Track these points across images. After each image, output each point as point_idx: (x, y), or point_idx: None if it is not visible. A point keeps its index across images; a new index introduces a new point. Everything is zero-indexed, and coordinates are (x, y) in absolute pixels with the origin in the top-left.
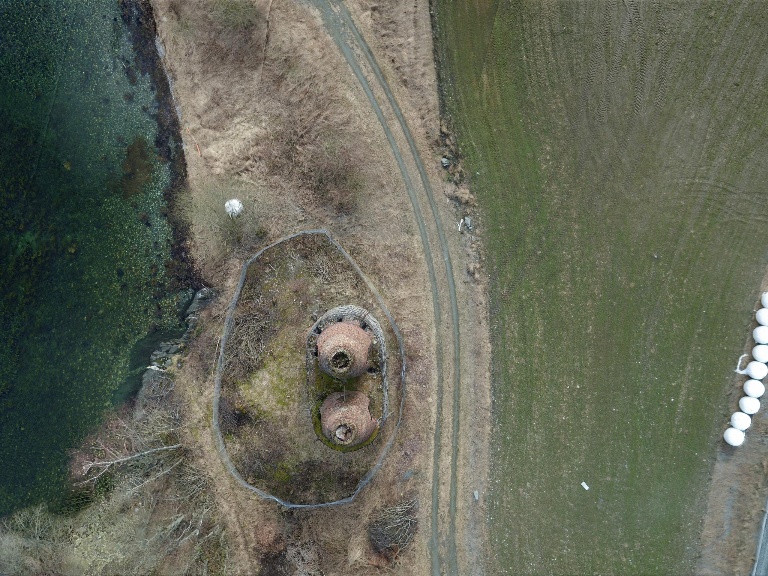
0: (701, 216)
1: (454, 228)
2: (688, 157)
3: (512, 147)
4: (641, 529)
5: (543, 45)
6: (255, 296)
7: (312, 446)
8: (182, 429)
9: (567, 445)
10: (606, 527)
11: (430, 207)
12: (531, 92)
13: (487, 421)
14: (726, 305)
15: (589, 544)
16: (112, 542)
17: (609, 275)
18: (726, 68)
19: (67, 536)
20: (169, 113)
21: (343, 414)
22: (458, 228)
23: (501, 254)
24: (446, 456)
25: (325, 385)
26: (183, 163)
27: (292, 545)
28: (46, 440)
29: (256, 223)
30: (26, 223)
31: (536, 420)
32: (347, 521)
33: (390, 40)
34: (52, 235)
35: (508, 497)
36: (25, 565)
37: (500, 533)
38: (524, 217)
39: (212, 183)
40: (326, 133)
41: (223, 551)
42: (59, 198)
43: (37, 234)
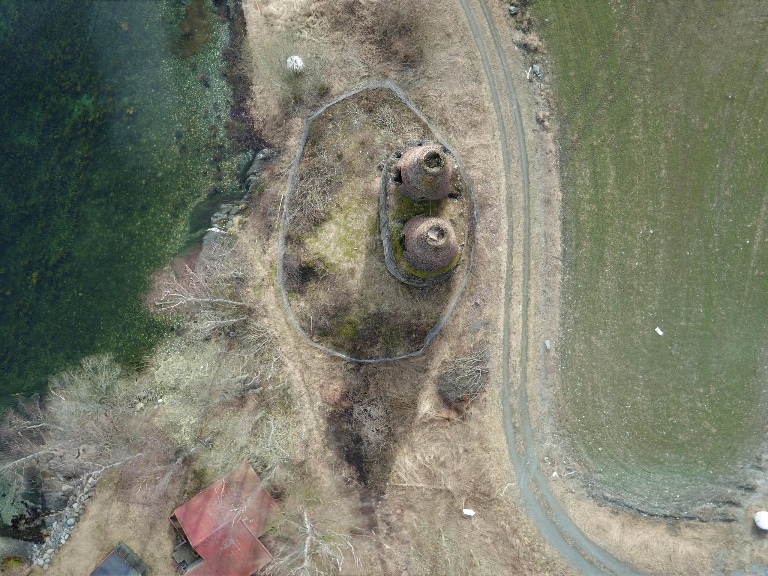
0: None
1: (523, 76)
2: None
3: None
4: (716, 373)
5: None
6: (319, 152)
7: (380, 298)
8: (245, 288)
9: (640, 291)
10: (681, 372)
11: (498, 55)
12: None
13: (558, 270)
14: None
15: (664, 390)
16: (174, 406)
17: (682, 117)
18: None
19: (128, 400)
20: None
21: (433, 219)
22: (527, 76)
23: (571, 101)
24: (517, 305)
25: (406, 209)
26: (242, 22)
27: (359, 402)
28: (105, 305)
29: (318, 80)
30: (83, 85)
31: (608, 267)
32: (415, 376)
33: None
34: (109, 97)
35: (580, 345)
36: (86, 429)
37: (572, 382)
38: (594, 62)
39: (272, 41)
40: None
41: (288, 409)
42: (116, 60)
43: (94, 97)
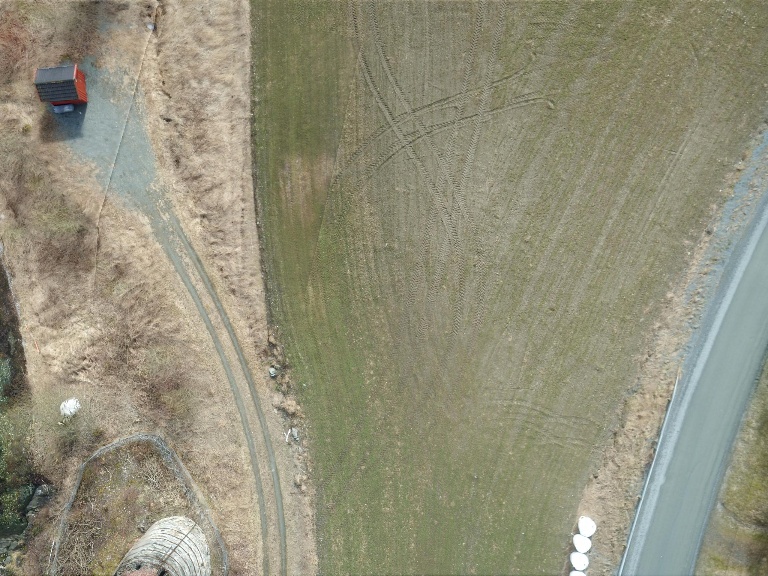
0: (519, 438)
1: (281, 439)
2: (506, 379)
3: (337, 360)
4: None
5: (366, 260)
6: (90, 499)
7: None
8: None
9: None
10: None
11: (258, 417)
12: (355, 306)
13: None
14: (544, 527)
15: None
16: None
17: (430, 493)
18: (542, 293)
19: None
20: (8, 309)
21: None
22: (286, 439)
23: (327, 467)
24: None
25: None
26: (22, 359)
27: None
28: None
29: (93, 422)
30: None
31: None
32: None
33: (219, 248)
34: None
35: None
36: None
37: None
38: (349, 431)
39: (50, 381)
40: (157, 339)
41: None
42: None
43: None
